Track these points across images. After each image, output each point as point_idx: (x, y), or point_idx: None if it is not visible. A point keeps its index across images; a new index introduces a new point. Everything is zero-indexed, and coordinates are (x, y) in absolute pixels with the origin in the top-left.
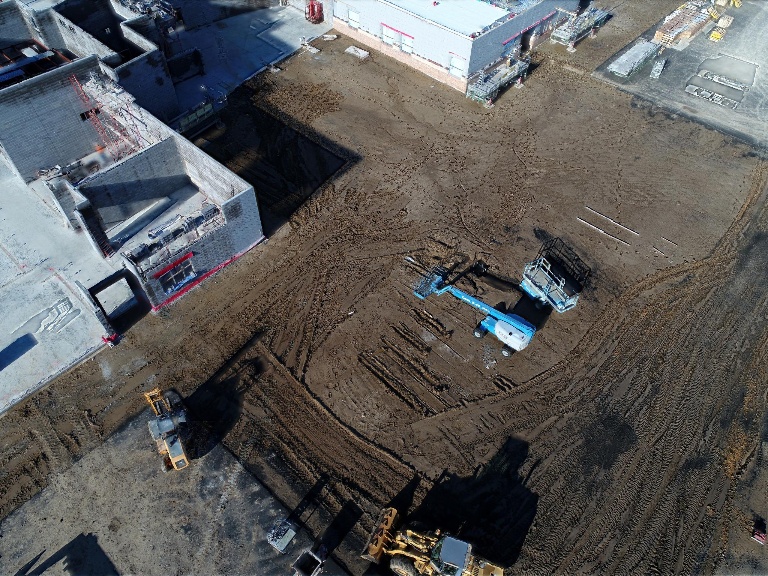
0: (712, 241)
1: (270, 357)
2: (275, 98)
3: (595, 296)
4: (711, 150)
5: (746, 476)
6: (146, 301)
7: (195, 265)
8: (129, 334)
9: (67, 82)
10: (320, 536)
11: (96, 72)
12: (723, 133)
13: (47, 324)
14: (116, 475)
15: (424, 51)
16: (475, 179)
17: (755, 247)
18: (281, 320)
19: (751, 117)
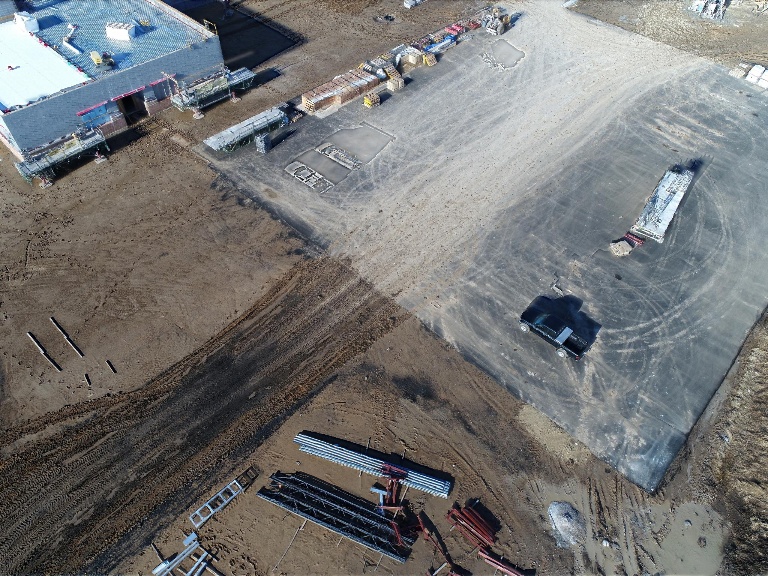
0: (162, 367)
1: None
2: None
3: None
4: (257, 245)
5: None
6: None
7: None
8: None
9: None
10: None
11: None
12: (285, 224)
13: None
14: None
15: None
16: None
17: (206, 376)
18: None
19: (333, 204)
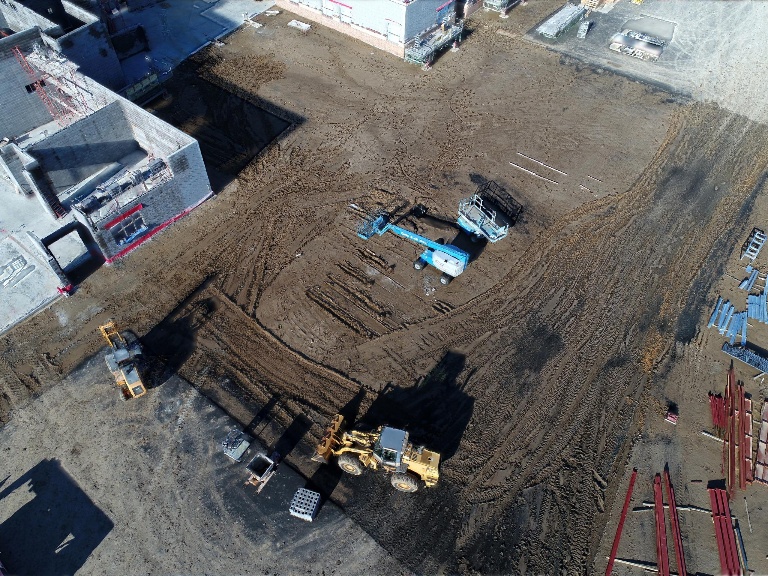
0: (633, 176)
1: (222, 297)
2: (220, 70)
3: (526, 229)
4: (633, 99)
5: (662, 370)
6: (99, 255)
7: (145, 218)
8: (84, 285)
9: (10, 54)
10: (273, 445)
11: (38, 43)
12: (644, 83)
13: (2, 280)
14: (76, 407)
15: (362, 20)
16: (414, 134)
17: (672, 180)
18: (231, 265)
19: (669, 68)
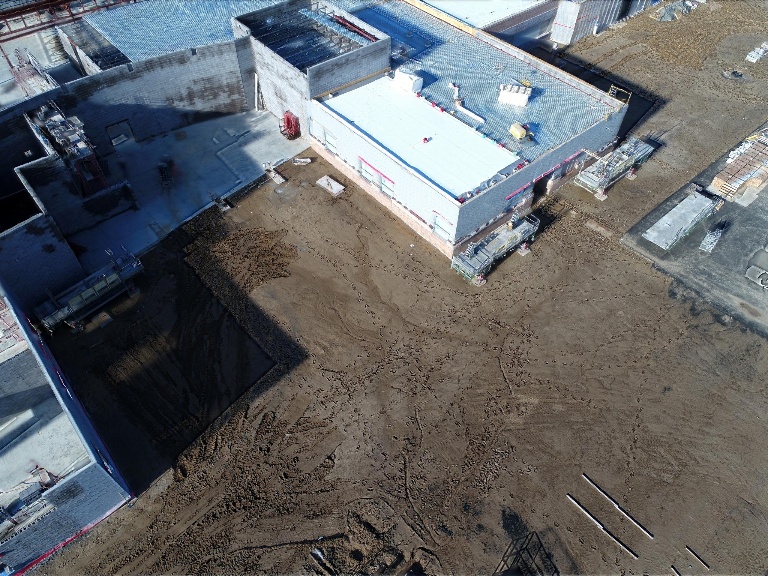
0: (761, 564)
1: None
2: (213, 251)
3: None
4: None
5: None
6: None
7: (9, 562)
8: None
9: None
10: None
11: None
12: None
13: None
14: None
15: (405, 200)
16: (438, 408)
17: None
18: None
19: None
